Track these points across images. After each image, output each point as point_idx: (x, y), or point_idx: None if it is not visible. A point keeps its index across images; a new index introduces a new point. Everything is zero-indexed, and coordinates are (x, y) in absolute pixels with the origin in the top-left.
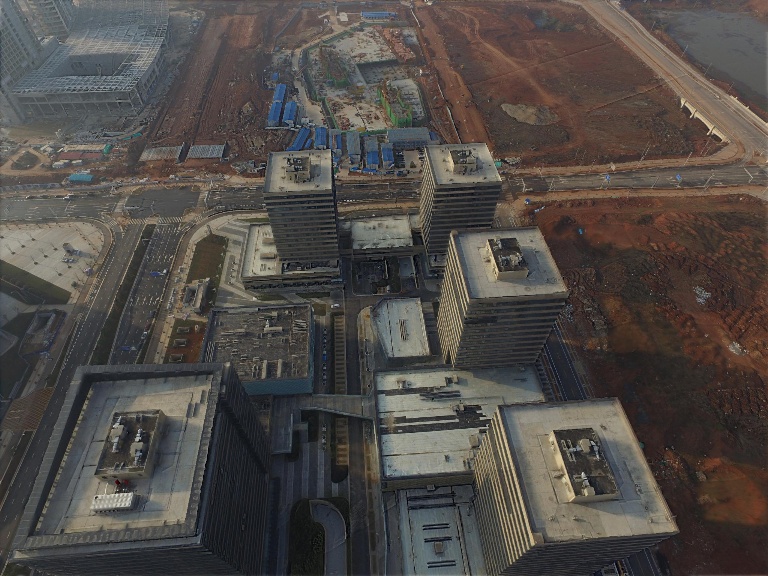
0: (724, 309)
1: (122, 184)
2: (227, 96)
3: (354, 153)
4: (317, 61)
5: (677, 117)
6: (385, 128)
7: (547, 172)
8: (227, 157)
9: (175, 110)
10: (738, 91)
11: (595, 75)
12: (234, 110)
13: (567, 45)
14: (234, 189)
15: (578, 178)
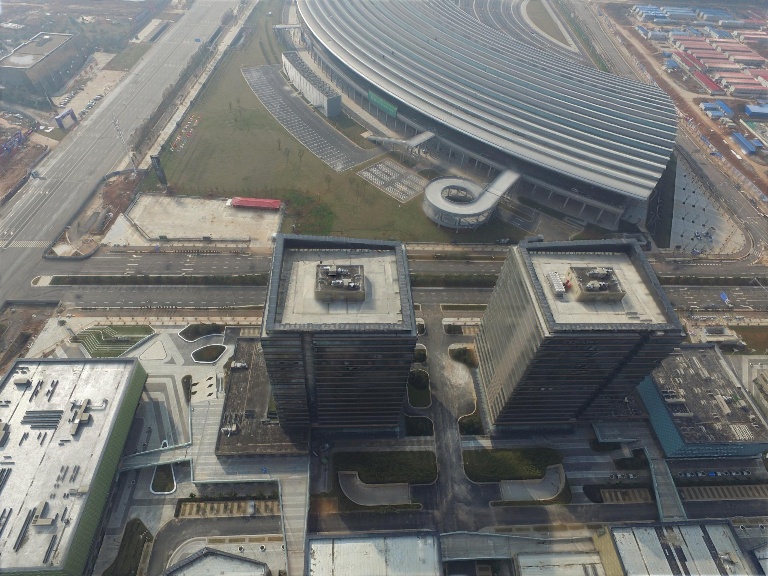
0: None
1: None
2: None
3: None
4: None
5: None
6: None
7: None
8: None
9: None
10: None
11: None
12: None
13: None
14: None
15: None
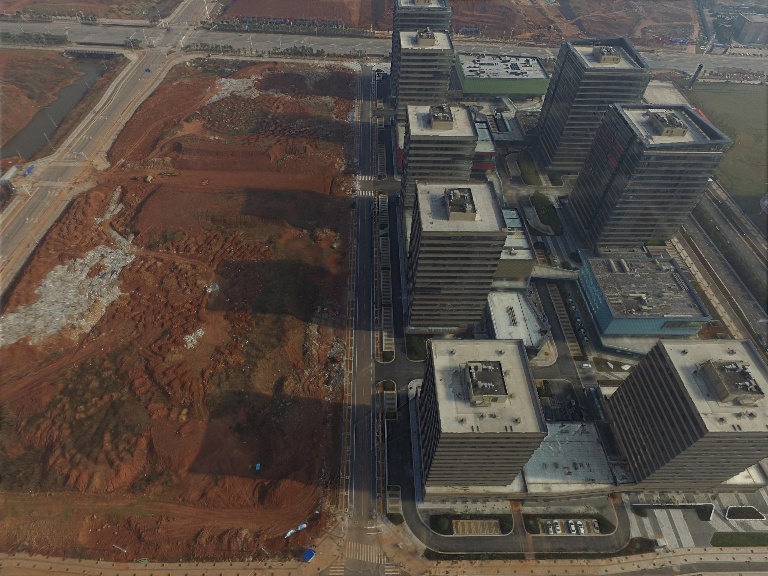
0: None
1: None
2: None
3: None
4: None
5: None
6: None
7: None
8: None
9: None
10: None
11: None
12: None
13: None
14: None
15: None
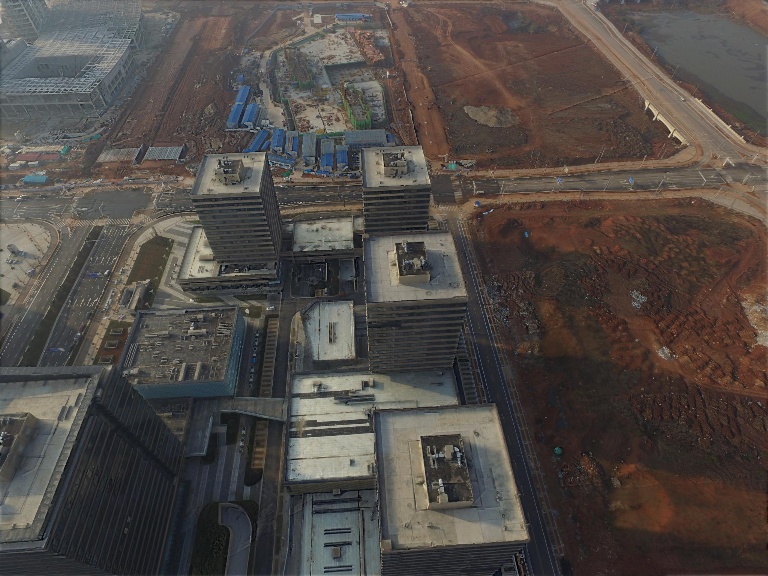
0: (659, 313)
1: (75, 185)
2: (191, 98)
3: (308, 155)
4: (285, 63)
5: (640, 119)
6: (344, 130)
7: (501, 175)
8: (183, 159)
9: (138, 112)
10: (705, 93)
11: (562, 77)
12: (196, 112)
13: (538, 47)
14: (186, 191)
15: (531, 181)
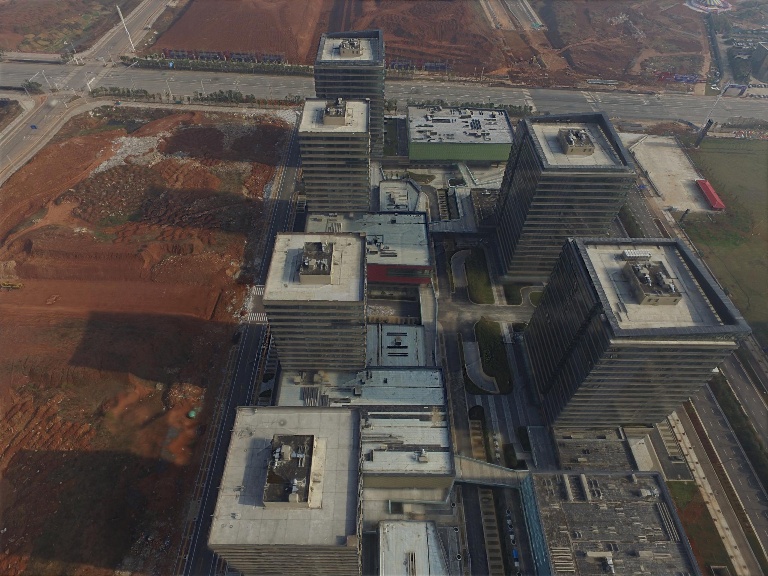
0: None
1: None
2: None
3: None
4: None
5: None
6: None
7: None
8: None
9: None
10: None
11: None
12: None
13: None
14: None
15: None
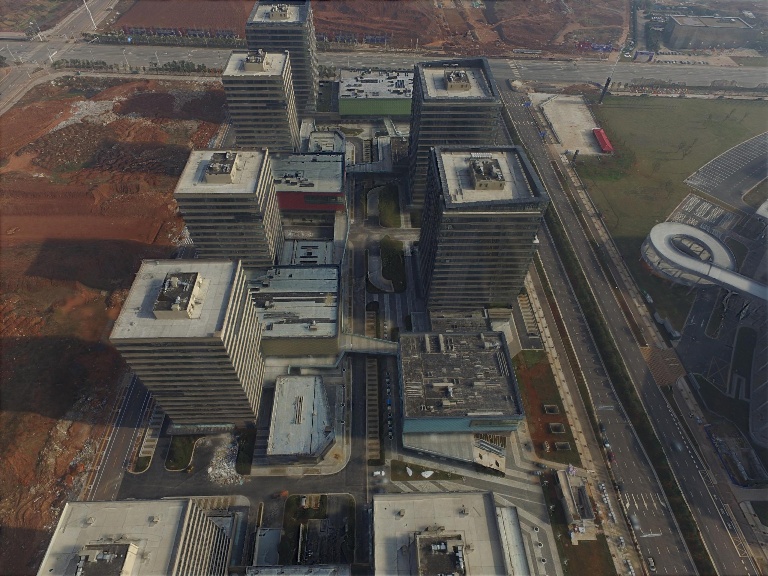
0: None
1: None
2: None
3: None
4: None
5: None
6: None
7: None
8: None
9: None
10: None
11: None
12: None
13: None
14: None
15: None
